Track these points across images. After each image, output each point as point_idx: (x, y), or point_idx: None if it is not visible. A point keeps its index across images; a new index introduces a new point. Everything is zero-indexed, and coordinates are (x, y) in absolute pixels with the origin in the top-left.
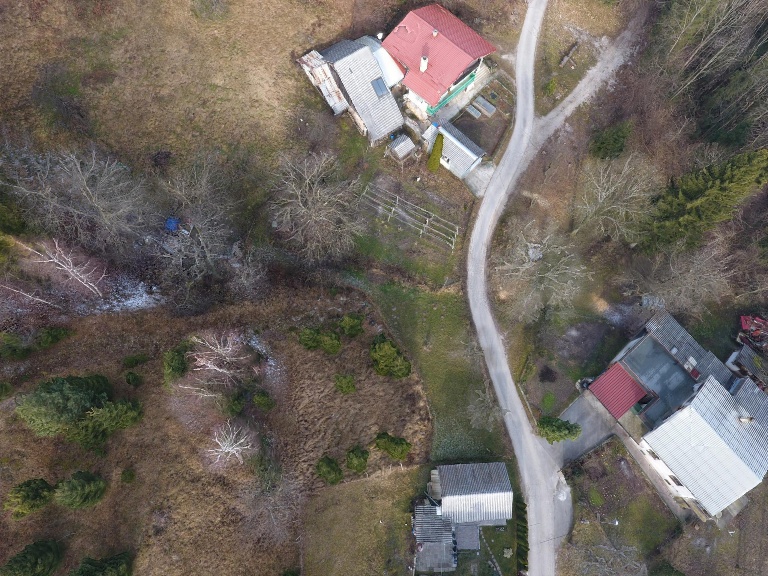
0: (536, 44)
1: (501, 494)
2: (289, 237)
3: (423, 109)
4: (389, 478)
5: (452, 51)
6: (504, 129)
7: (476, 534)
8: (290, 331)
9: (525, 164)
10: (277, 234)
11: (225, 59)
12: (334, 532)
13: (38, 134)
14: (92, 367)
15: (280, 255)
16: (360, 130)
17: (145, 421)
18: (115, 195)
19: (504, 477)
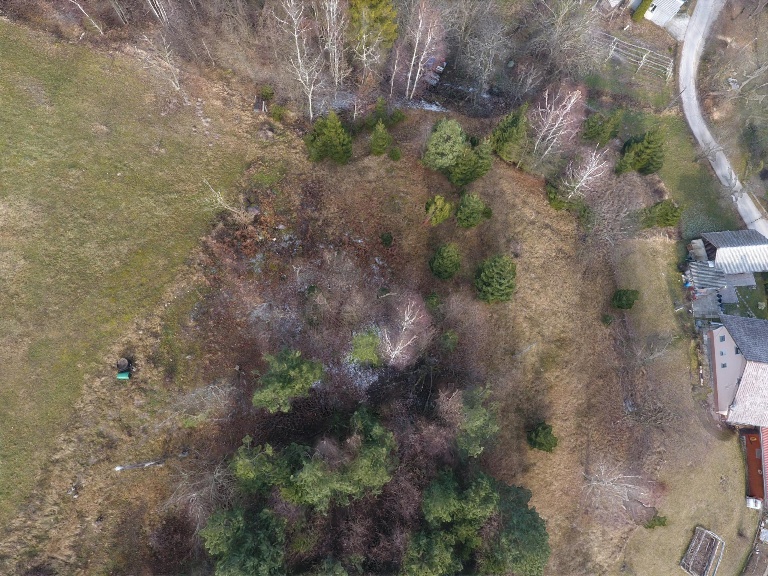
0: None
1: (765, 246)
2: None
3: None
4: (660, 244)
5: None
6: None
7: (733, 291)
8: None
9: (715, 14)
10: (514, 72)
11: None
12: (637, 273)
13: None
14: None
15: None
16: None
17: (485, 178)
18: (427, 8)
19: (761, 237)
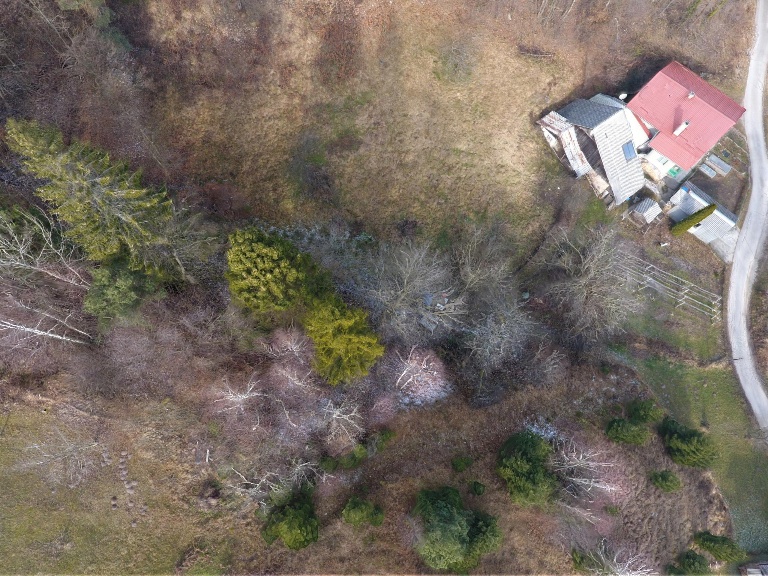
0: (762, 98)
1: None
2: (542, 309)
3: (663, 170)
4: None
5: (710, 114)
6: (741, 189)
7: None
8: (579, 417)
9: None
10: None
11: (469, 123)
12: None
13: (285, 205)
14: (425, 474)
15: (536, 329)
16: (597, 192)
17: None
18: None
19: None
